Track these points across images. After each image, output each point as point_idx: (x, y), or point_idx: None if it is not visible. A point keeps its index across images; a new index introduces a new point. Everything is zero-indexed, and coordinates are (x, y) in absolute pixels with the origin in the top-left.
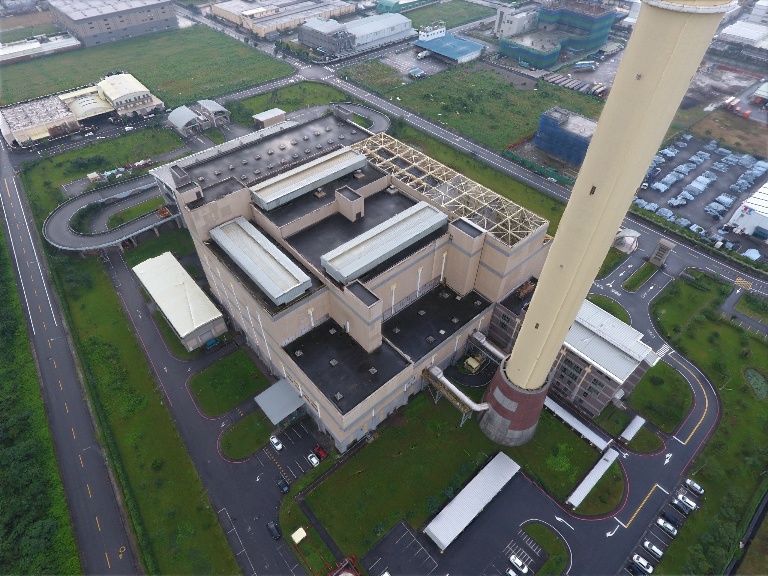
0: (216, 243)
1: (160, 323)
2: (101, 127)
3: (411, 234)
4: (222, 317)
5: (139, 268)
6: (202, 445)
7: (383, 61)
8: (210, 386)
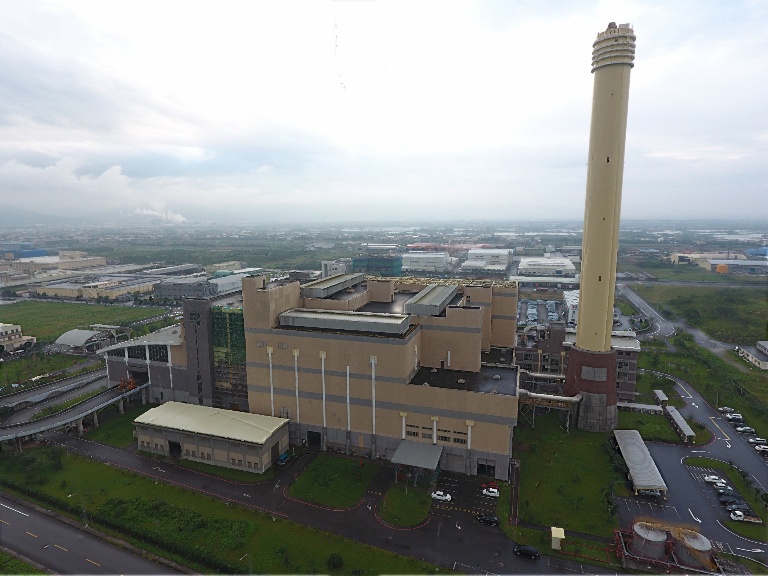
0: (287, 326)
1: (197, 466)
2: None
3: (449, 291)
4: (287, 424)
5: (145, 417)
6: (366, 530)
7: None
8: (319, 486)
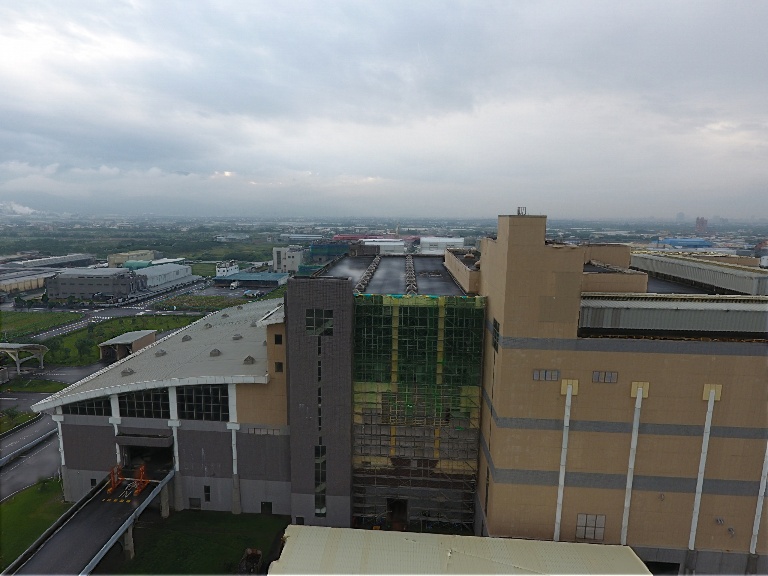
0: (597, 331)
1: None
2: None
3: None
4: None
5: None
6: None
7: (195, 295)
8: None
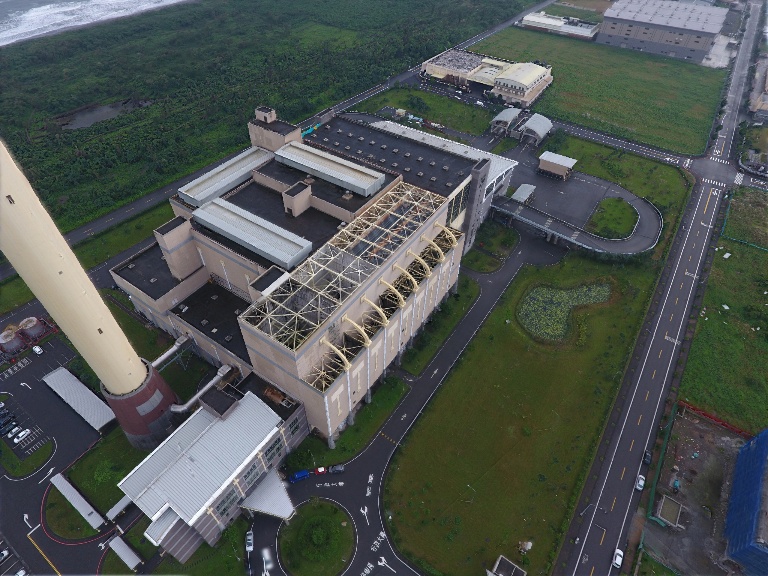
0: None
1: None
2: (474, 93)
3: (252, 241)
4: None
5: None
6: (153, 241)
7: None
8: None
